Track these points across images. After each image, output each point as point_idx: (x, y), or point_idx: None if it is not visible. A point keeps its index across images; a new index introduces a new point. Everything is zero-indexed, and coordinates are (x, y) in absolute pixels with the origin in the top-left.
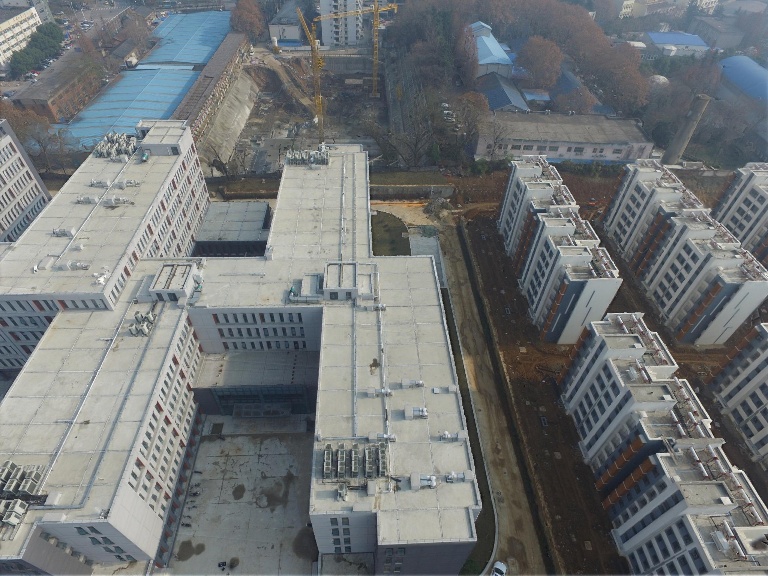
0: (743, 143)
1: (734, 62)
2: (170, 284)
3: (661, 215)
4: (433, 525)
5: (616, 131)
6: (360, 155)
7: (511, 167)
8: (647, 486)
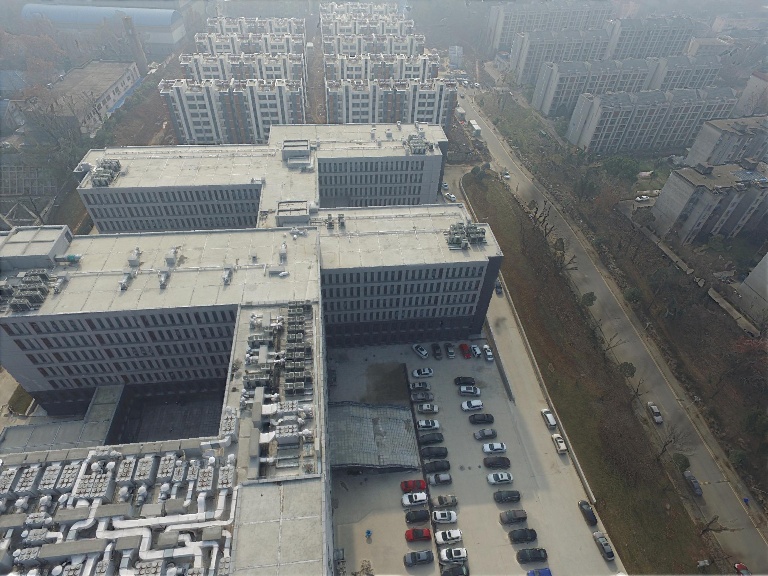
0: (122, 52)
1: (34, 9)
2: (301, 208)
3: (238, 67)
4: (437, 132)
5: (106, 69)
6: (111, 151)
7: (165, 96)
8: (403, 105)
